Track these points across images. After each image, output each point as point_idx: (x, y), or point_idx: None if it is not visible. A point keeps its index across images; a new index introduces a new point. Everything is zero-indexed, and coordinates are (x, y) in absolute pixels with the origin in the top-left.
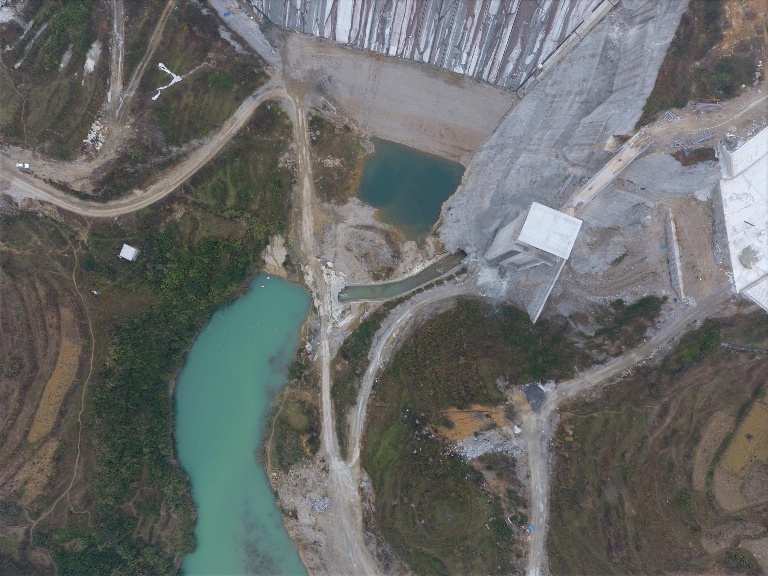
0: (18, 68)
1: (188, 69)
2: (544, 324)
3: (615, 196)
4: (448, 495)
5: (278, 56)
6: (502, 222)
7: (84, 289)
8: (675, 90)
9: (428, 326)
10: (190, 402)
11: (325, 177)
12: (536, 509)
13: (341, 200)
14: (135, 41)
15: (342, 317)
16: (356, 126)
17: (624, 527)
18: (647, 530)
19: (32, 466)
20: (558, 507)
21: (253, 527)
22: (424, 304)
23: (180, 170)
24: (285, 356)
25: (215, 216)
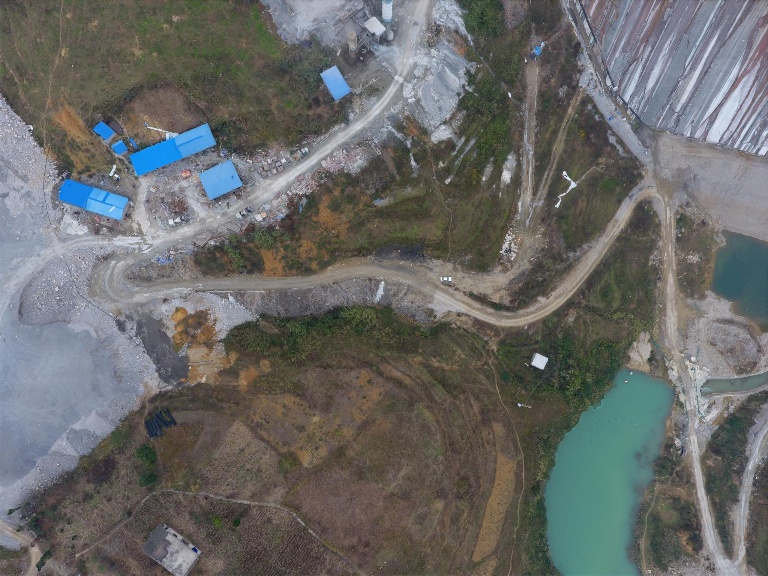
0: (450, 184)
1: (581, 174)
2: None
3: None
4: None
5: (650, 156)
6: None
7: (508, 402)
8: None
9: None
10: (554, 498)
11: (689, 273)
12: None
13: (702, 295)
14: (544, 151)
15: (708, 412)
16: (710, 220)
17: None
18: None
19: None
20: None
21: None
22: None
23: (574, 275)
24: (651, 451)
25: (603, 318)
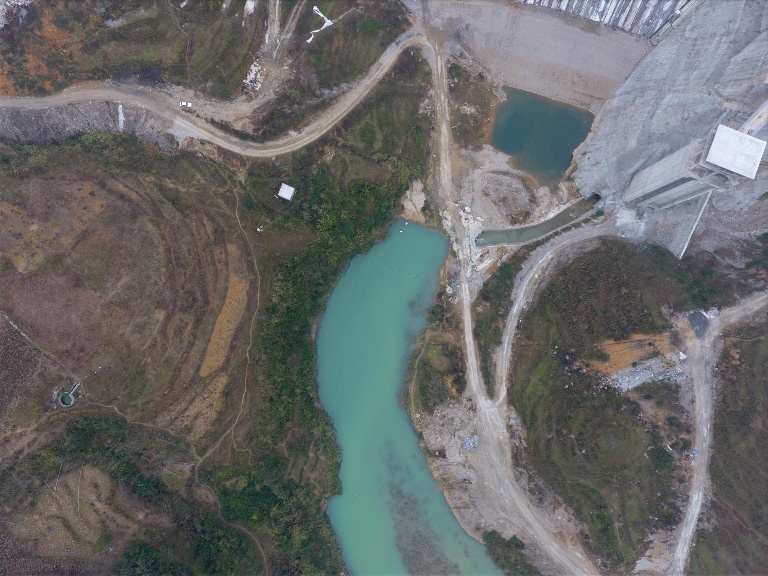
0: (184, 7)
1: (338, 14)
2: (691, 259)
3: None
4: (610, 424)
5: (419, 4)
6: (645, 162)
7: (247, 226)
8: None
9: (579, 263)
10: (329, 347)
11: (462, 123)
12: (700, 434)
13: (477, 146)
14: None
15: (481, 261)
16: (489, 75)
17: None
18: None
19: (202, 401)
20: (724, 430)
21: (397, 469)
22: (564, 245)
23: (331, 113)
24: (424, 300)
25: (363, 159)
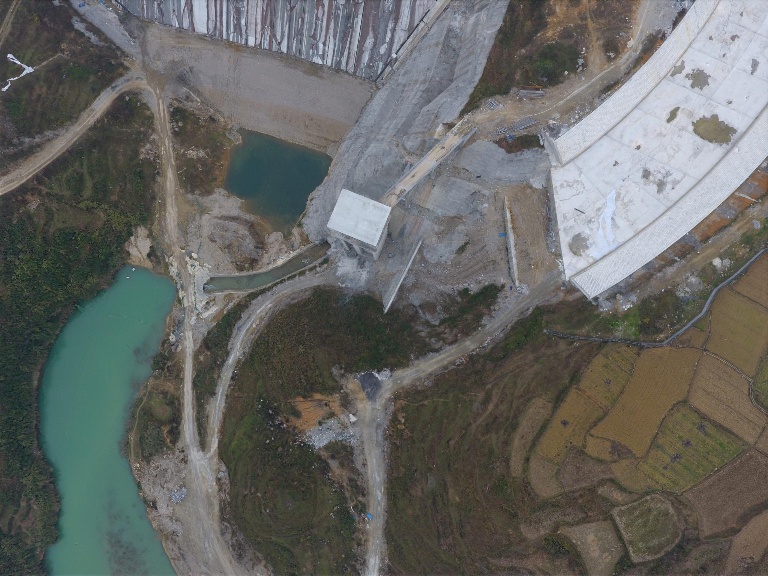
0: None
1: (41, 60)
2: (394, 313)
3: (453, 184)
4: (290, 484)
5: (137, 47)
6: None
7: None
8: (499, 77)
9: (279, 316)
10: (57, 394)
11: (188, 168)
12: (374, 497)
13: (206, 191)
14: None
15: (206, 308)
16: (222, 117)
17: (449, 514)
18: (470, 517)
19: None
20: (393, 495)
21: (117, 518)
22: (284, 294)
23: (33, 161)
24: (150, 347)
25: (71, 207)
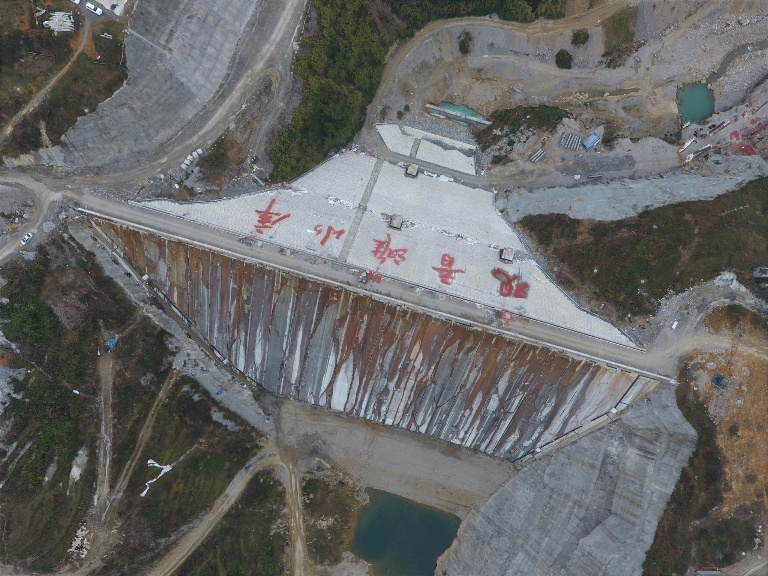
0: None
1: (178, 456)
2: None
3: None
4: None
5: (271, 424)
6: None
7: None
8: (675, 553)
9: None
10: None
11: (318, 539)
12: None
13: (334, 560)
14: (123, 442)
15: None
16: (351, 479)
17: None
18: None
19: None
20: None
21: None
22: None
23: (168, 560)
24: None
25: None
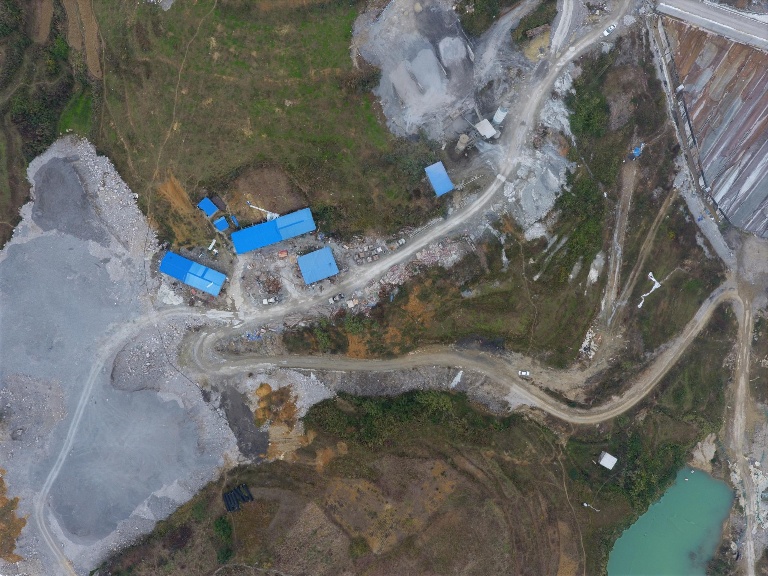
0: (538, 281)
1: (665, 275)
2: None
3: None
4: None
5: (734, 258)
6: None
7: (574, 500)
8: None
9: None
10: None
11: (762, 377)
12: None
13: None
14: (632, 251)
15: (767, 518)
16: None
17: None
18: None
19: None
20: None
21: None
22: None
23: (649, 375)
24: (705, 552)
25: (673, 420)
